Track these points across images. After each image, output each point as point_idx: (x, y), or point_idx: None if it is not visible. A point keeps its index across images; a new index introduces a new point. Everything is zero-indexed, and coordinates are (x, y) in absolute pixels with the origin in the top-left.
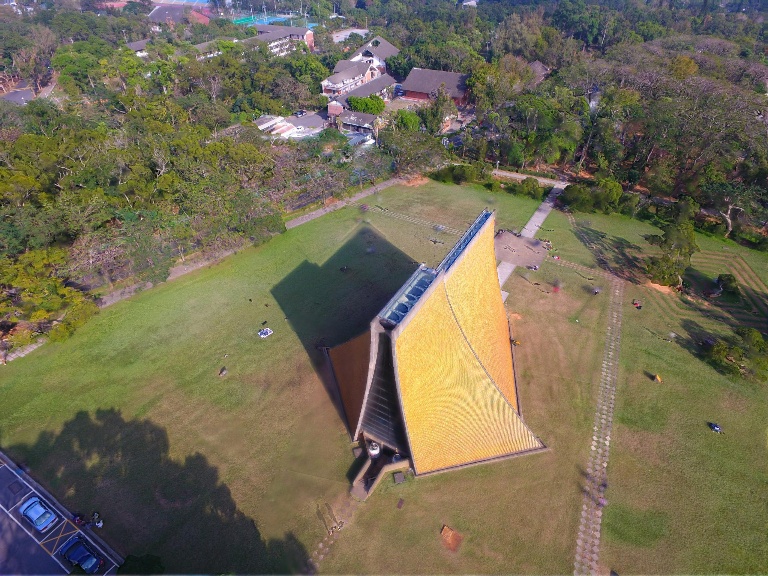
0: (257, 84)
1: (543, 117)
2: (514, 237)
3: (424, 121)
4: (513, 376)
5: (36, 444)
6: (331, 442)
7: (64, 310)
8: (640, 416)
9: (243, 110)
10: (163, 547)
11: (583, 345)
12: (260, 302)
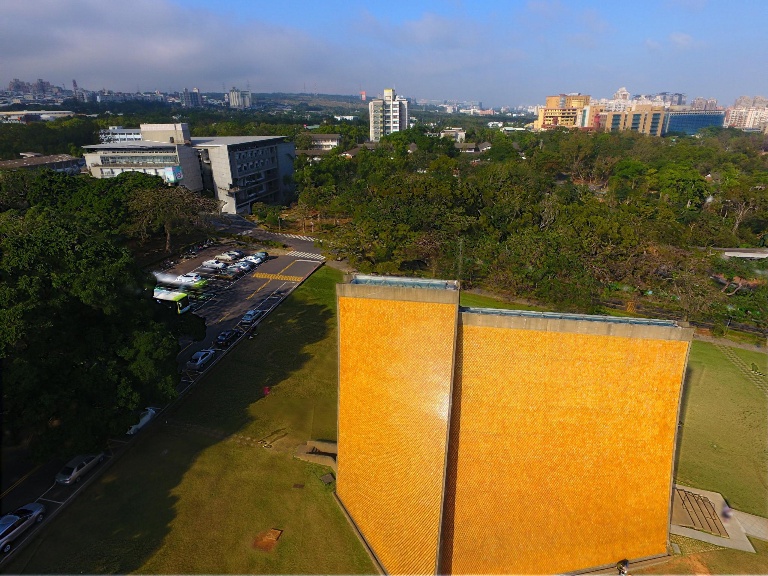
0: None
1: None
2: None
3: None
4: None
5: (297, 301)
6: None
7: (401, 272)
8: None
9: (766, 245)
10: (238, 363)
11: None
12: None
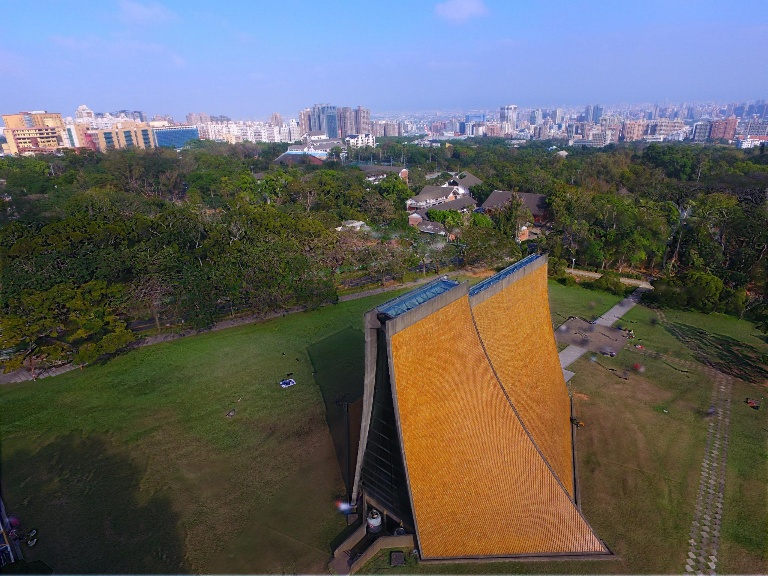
0: (347, 199)
1: (622, 213)
2: (587, 324)
3: (497, 225)
4: (571, 459)
5: (19, 452)
6: (323, 502)
7: None
8: (765, 537)
9: None
10: None
11: (673, 437)
12: (292, 356)
